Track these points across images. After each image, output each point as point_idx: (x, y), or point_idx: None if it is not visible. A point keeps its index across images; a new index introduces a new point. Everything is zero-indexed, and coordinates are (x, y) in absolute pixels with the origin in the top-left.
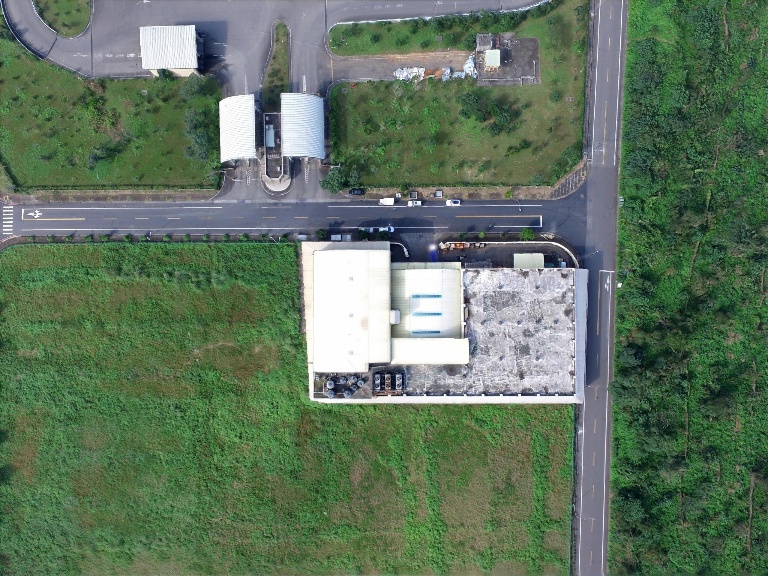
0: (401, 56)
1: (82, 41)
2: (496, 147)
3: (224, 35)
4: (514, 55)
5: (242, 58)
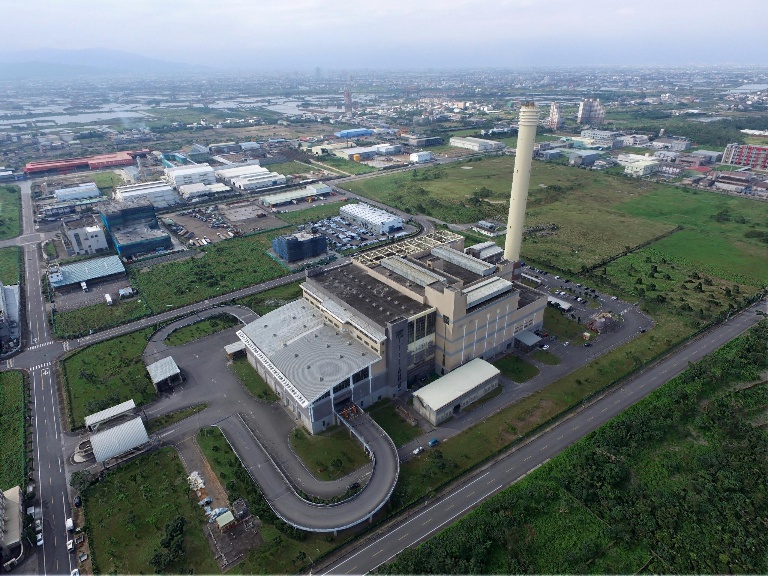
0: (210, 469)
1: (164, 348)
2: (143, 575)
3: (189, 388)
4: (242, 537)
5: (176, 401)
